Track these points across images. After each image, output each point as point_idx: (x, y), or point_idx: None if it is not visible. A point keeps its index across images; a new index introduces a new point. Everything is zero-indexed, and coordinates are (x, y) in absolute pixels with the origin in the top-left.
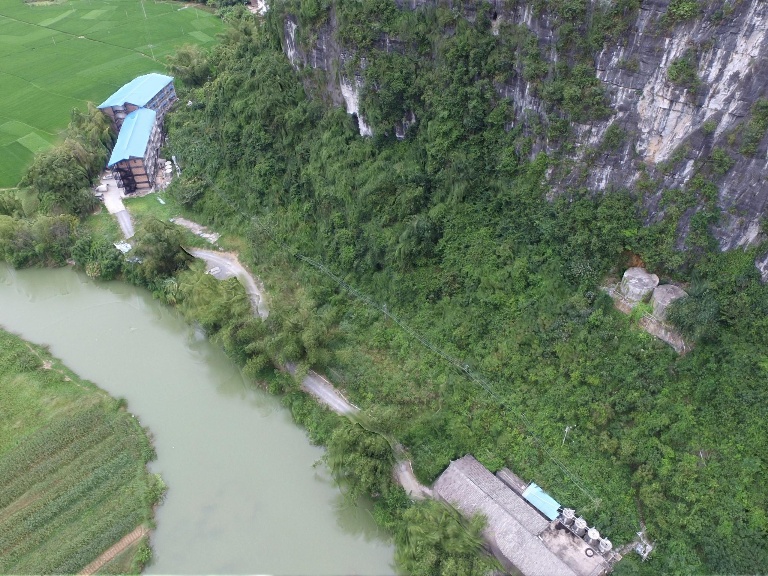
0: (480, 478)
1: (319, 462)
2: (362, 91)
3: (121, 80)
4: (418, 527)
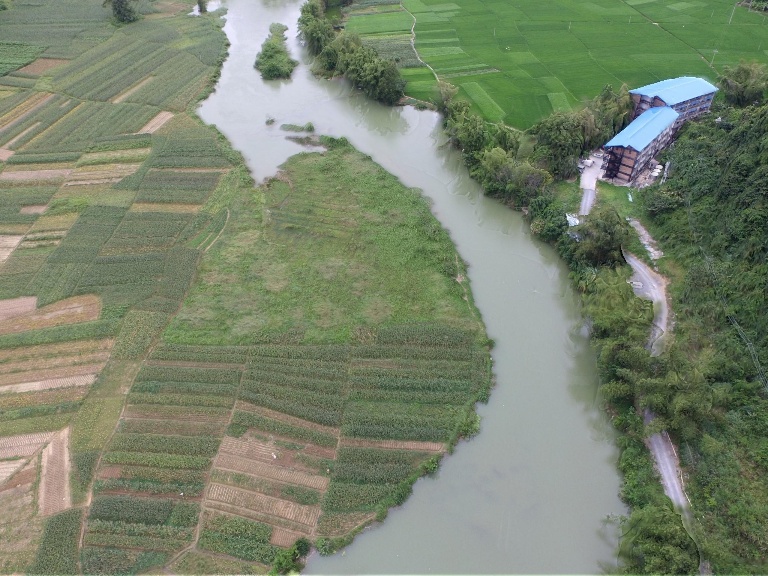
0: None
1: (615, 517)
2: None
3: (666, 74)
4: None
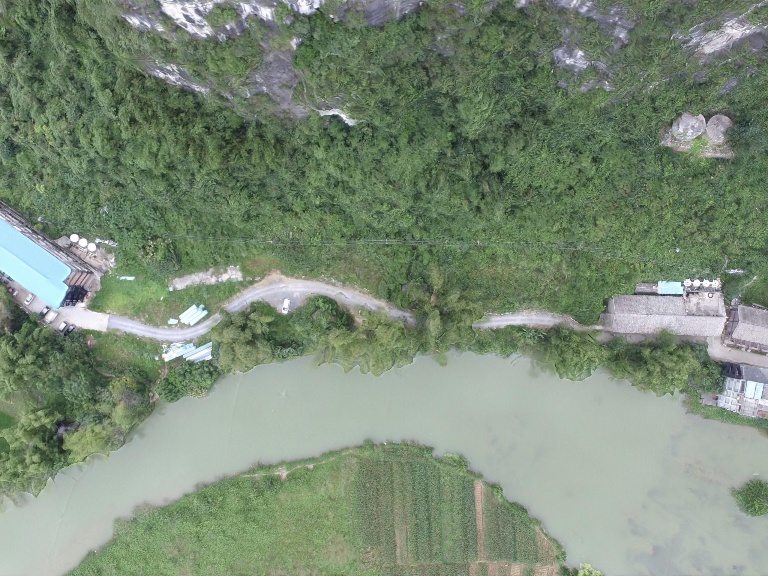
0: (635, 307)
1: None
2: (355, 109)
3: None
4: (645, 373)
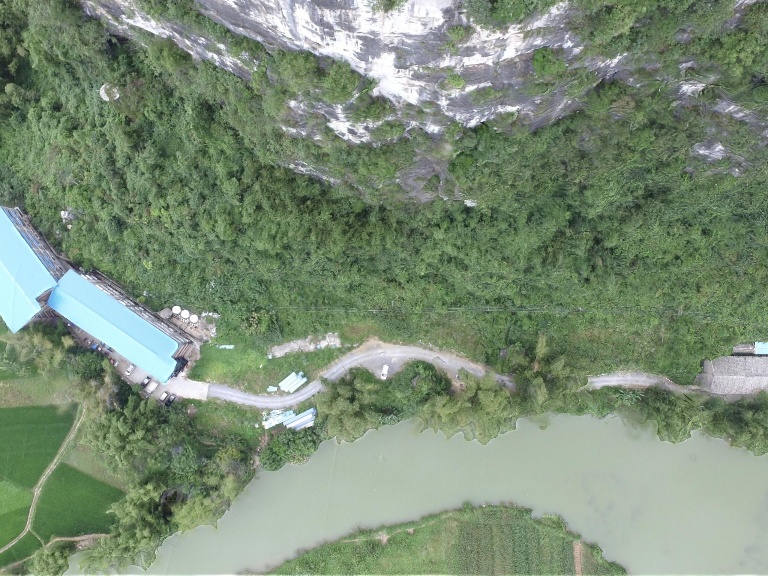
0: (733, 368)
1: None
2: None
3: None
4: (748, 436)
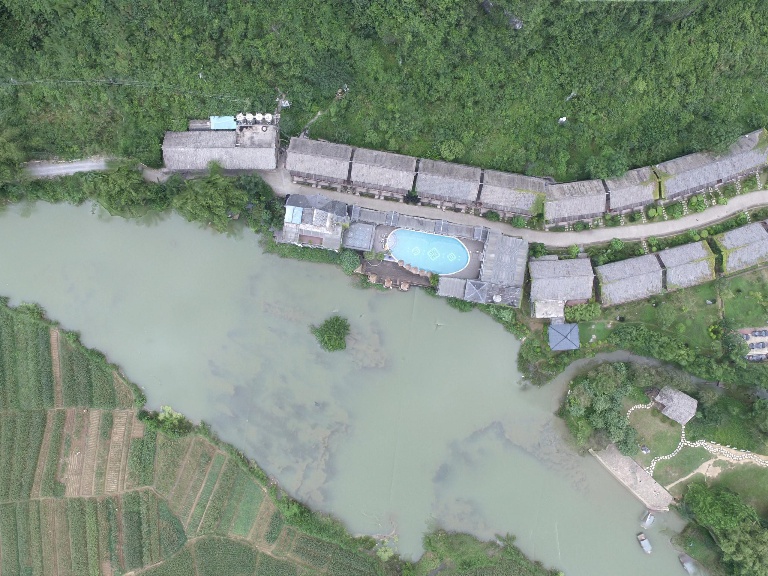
0: (184, 142)
1: (94, 210)
2: None
3: None
4: (181, 201)
